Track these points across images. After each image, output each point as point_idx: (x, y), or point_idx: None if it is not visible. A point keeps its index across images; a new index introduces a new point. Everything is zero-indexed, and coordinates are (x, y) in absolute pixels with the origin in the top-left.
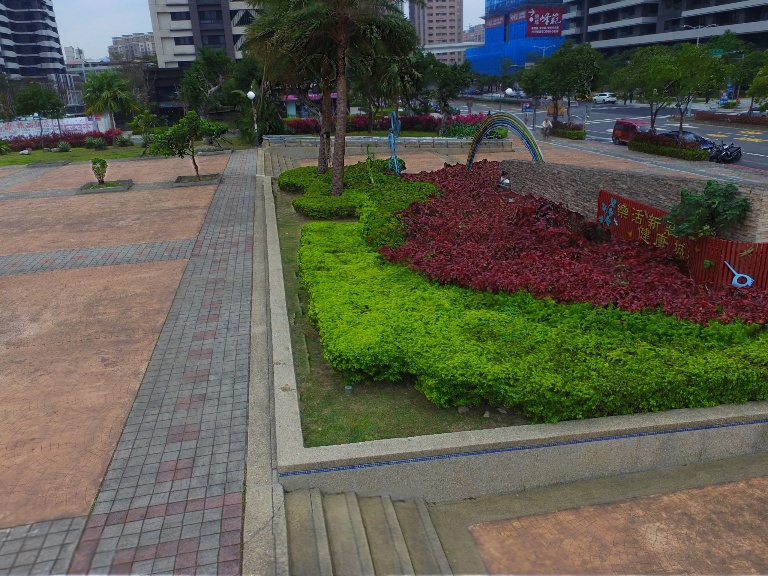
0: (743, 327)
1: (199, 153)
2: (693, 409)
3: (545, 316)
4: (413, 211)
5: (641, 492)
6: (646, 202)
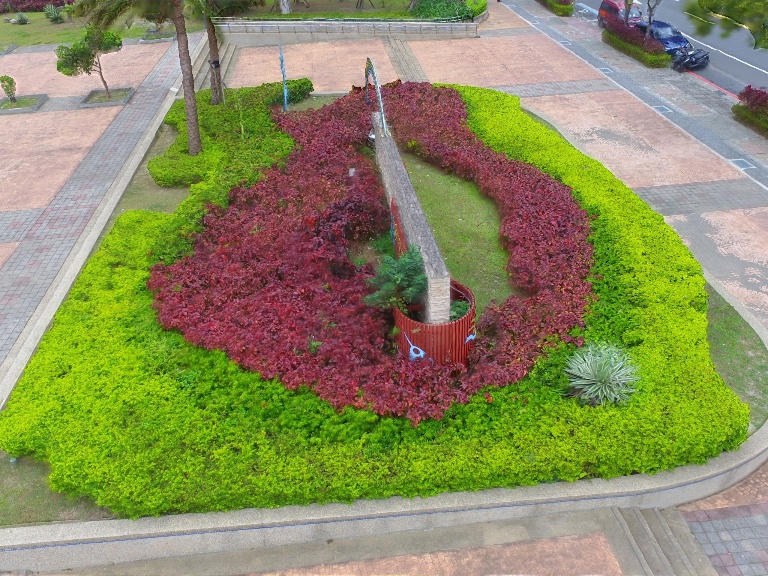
0: (365, 418)
1: (140, 41)
2: (260, 509)
3: (208, 391)
4: (230, 199)
5: (197, 575)
6: (406, 231)
